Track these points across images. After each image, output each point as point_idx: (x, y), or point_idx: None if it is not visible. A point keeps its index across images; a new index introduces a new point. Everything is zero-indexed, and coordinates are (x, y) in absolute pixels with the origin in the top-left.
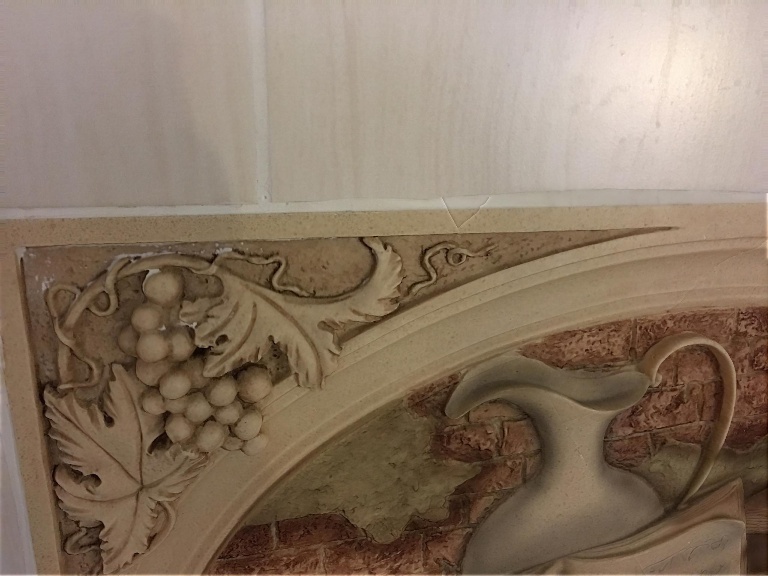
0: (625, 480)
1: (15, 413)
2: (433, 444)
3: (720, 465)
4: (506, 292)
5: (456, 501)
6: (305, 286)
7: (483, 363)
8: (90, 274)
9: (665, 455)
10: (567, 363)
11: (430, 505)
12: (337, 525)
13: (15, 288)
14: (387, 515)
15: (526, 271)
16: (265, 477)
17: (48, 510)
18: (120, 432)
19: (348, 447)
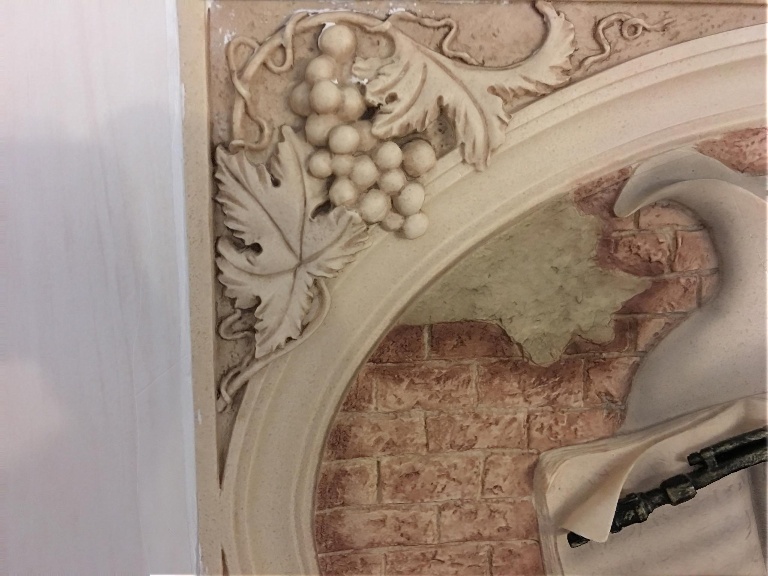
0: None
1: (188, 168)
2: (599, 250)
3: None
4: (684, 70)
5: (622, 321)
6: (474, 55)
7: (656, 156)
8: (269, 29)
9: None
10: (748, 167)
11: (594, 322)
12: (492, 338)
13: (201, 34)
14: (547, 330)
15: (707, 45)
16: (421, 273)
17: (208, 279)
18: (286, 193)
19: (509, 242)
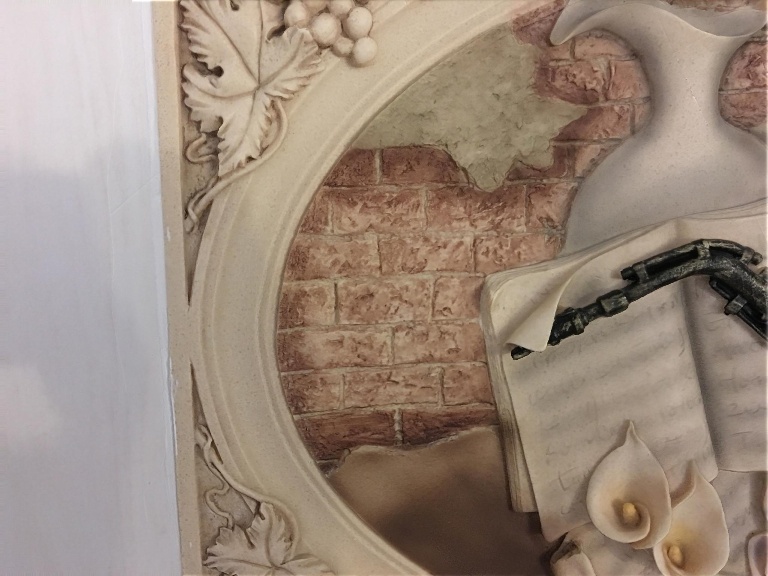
0: (744, 138)
1: None
2: (537, 78)
3: None
4: None
5: (561, 147)
6: None
7: None
8: None
9: None
10: None
11: (534, 147)
12: (440, 163)
13: None
14: (490, 155)
15: None
16: (372, 101)
17: (175, 101)
18: (244, 16)
19: (453, 69)
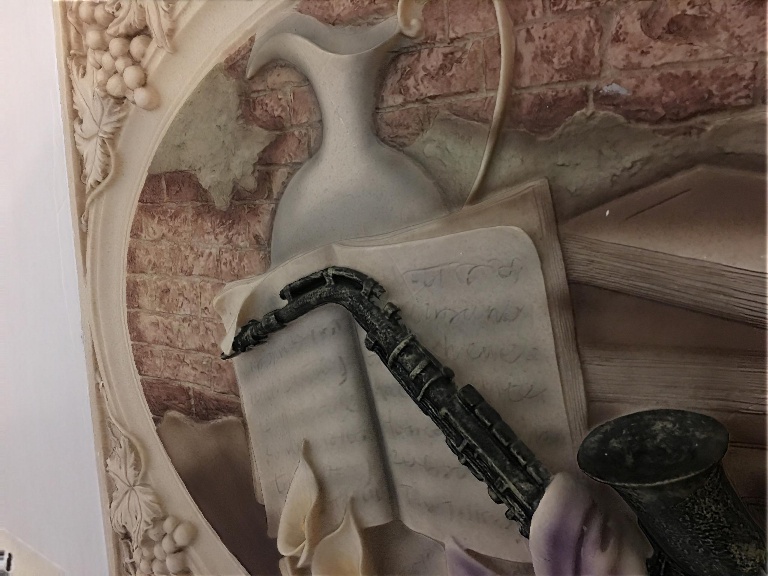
0: (394, 160)
1: (58, 72)
2: (244, 109)
3: (515, 156)
4: None
5: (261, 171)
6: None
7: (268, 21)
8: None
9: (439, 133)
10: (337, 18)
11: (243, 171)
12: (195, 185)
13: None
14: (219, 178)
15: None
16: None
17: (70, 143)
18: (85, 81)
19: (192, 107)
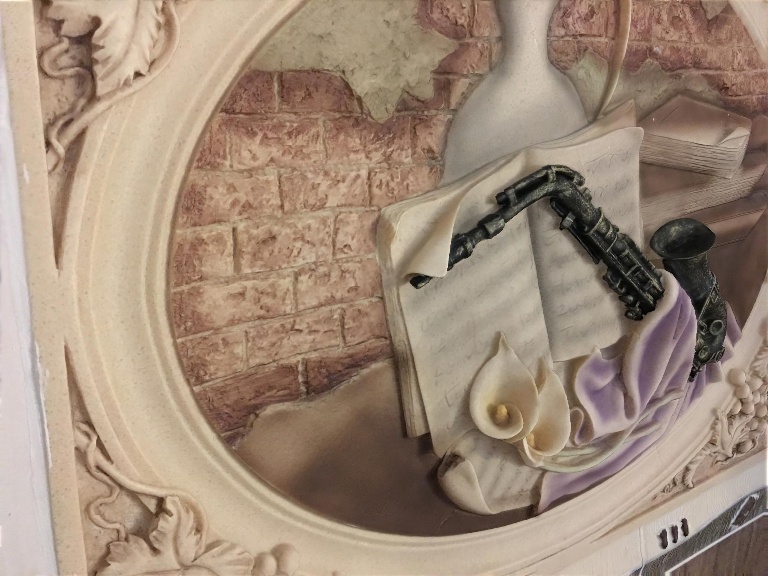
0: (563, 79)
1: None
2: (419, 9)
3: (620, 83)
4: None
5: (439, 79)
6: None
7: None
8: None
9: (587, 62)
10: None
11: (419, 78)
12: (336, 91)
13: None
14: (382, 84)
15: None
16: (267, 15)
17: None
18: None
19: None
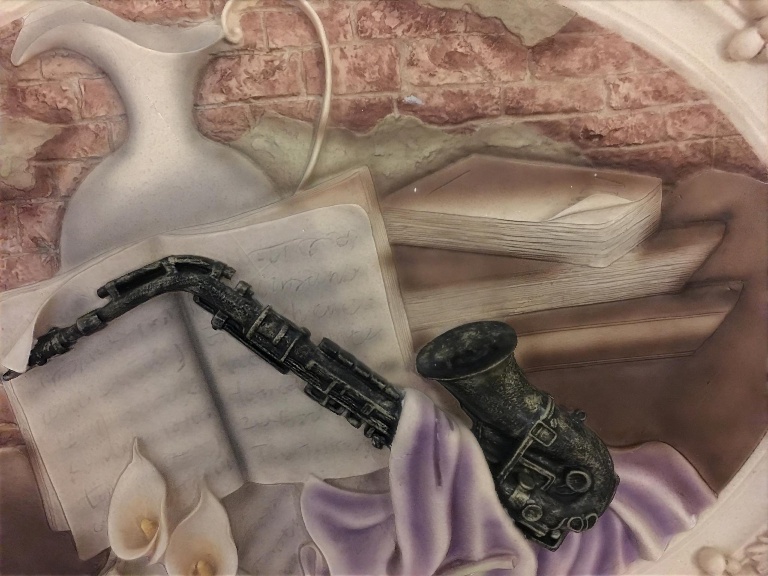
0: (222, 153)
1: None
2: (8, 99)
3: (339, 149)
4: None
5: (41, 167)
6: None
7: (43, 7)
8: None
9: (267, 129)
10: (139, 15)
11: (12, 168)
12: None
13: None
14: None
15: None
16: None
17: None
18: None
19: None
